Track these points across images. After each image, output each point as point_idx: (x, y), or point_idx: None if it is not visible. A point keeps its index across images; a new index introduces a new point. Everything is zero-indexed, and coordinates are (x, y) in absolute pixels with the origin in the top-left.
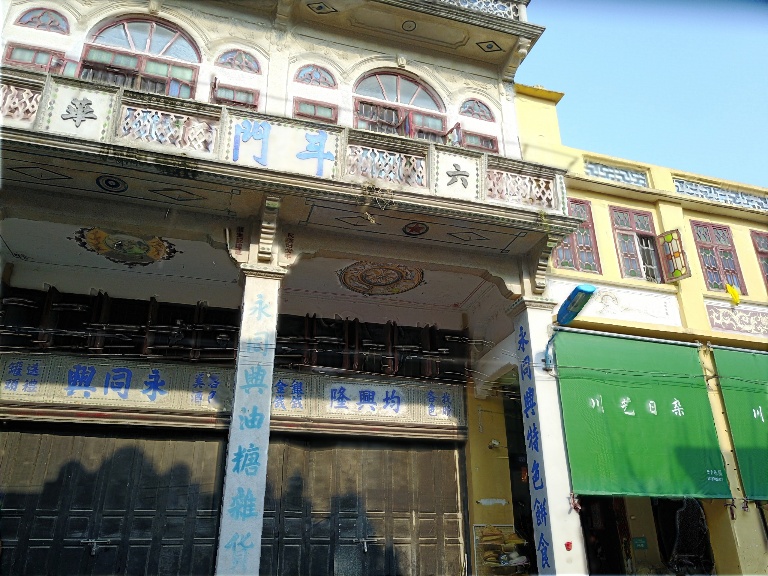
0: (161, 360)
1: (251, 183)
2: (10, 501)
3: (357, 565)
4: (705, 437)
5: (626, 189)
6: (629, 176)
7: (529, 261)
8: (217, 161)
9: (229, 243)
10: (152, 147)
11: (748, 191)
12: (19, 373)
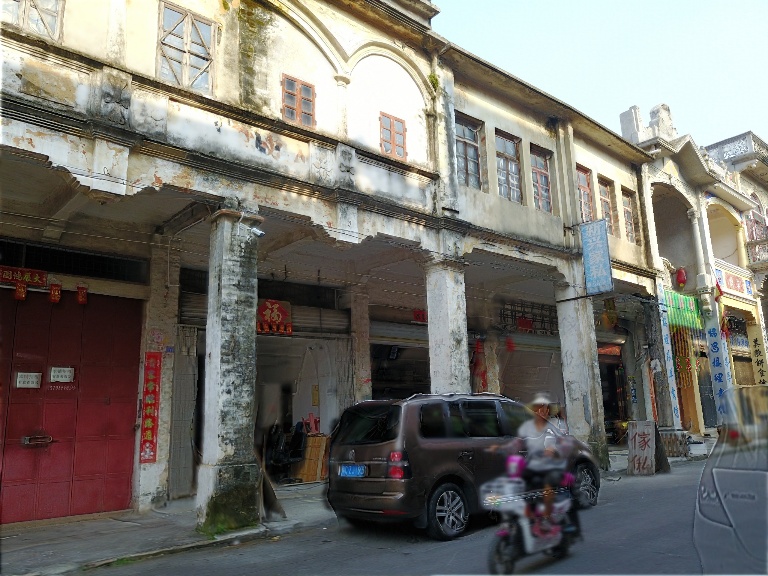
0: None
1: None
2: None
3: None
4: None
5: None
6: None
7: None
8: None
9: None
10: None
11: None
12: None
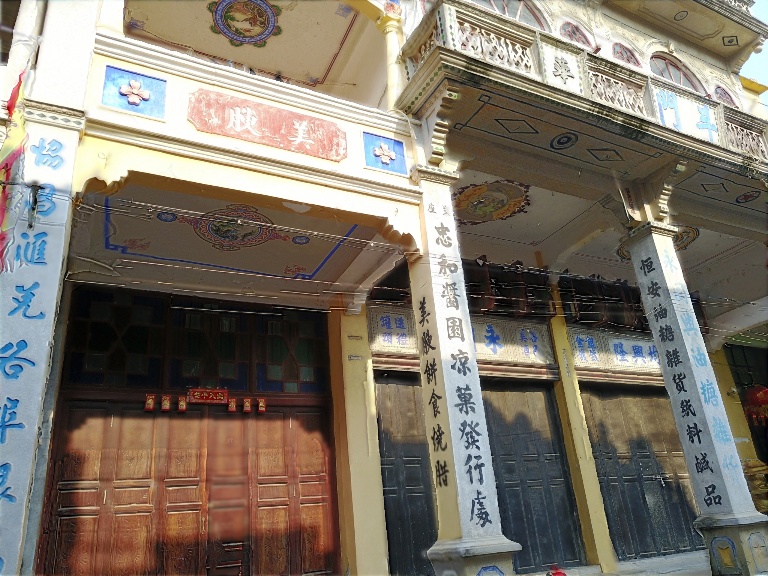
0: (492, 316)
1: (676, 147)
2: (407, 450)
3: (660, 498)
4: None
5: None
6: None
7: None
8: (662, 125)
9: (625, 203)
10: (620, 108)
11: None
12: (390, 326)
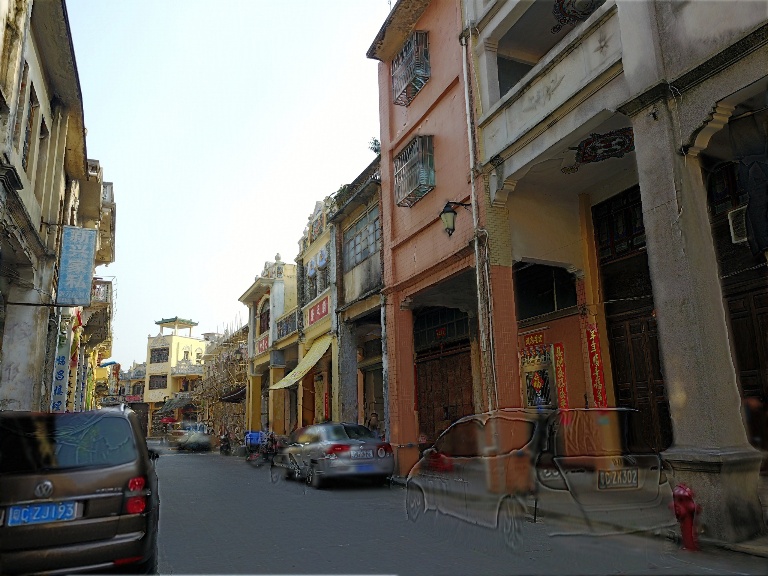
0: None
1: None
2: None
3: None
4: None
5: None
6: None
7: (91, 342)
8: None
9: None
10: None
11: None
12: None
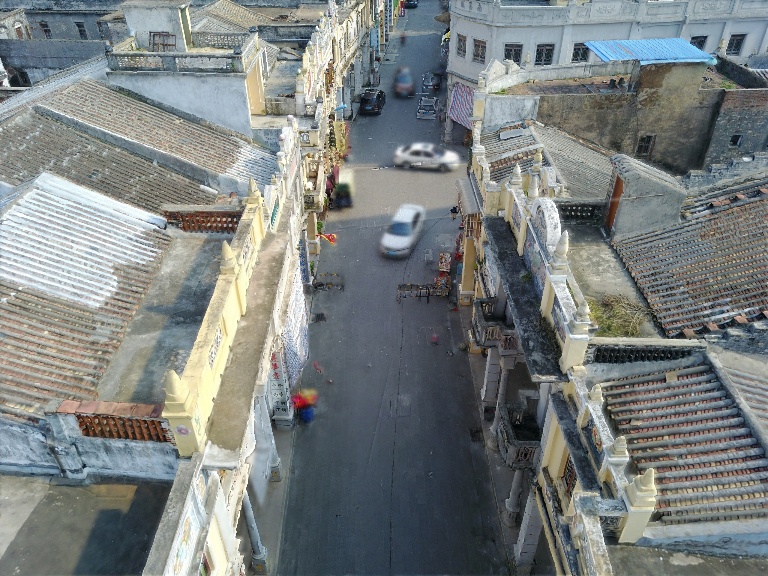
0: None
1: None
2: None
3: None
4: None
5: None
6: None
7: None
8: None
9: None
10: None
11: None
12: None
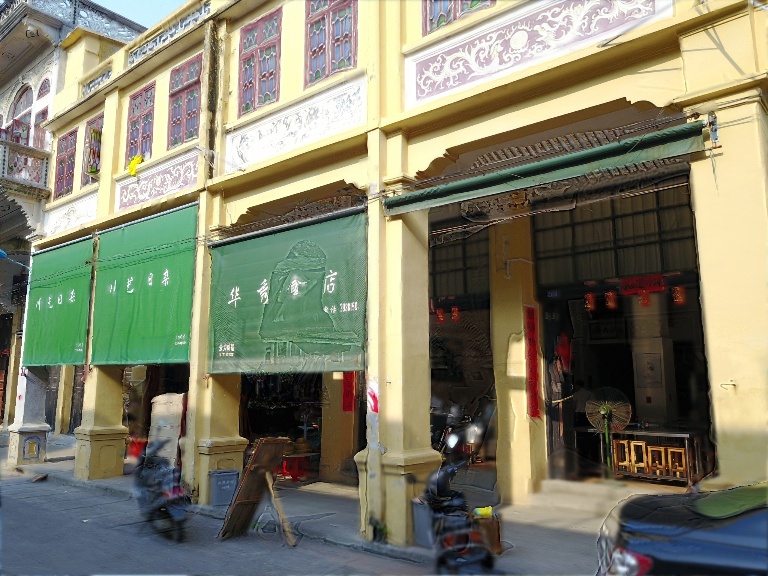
0: None
1: None
2: None
3: None
4: (81, 317)
5: (81, 104)
6: (102, 79)
7: None
8: None
9: None
10: None
11: (185, 13)
12: None
